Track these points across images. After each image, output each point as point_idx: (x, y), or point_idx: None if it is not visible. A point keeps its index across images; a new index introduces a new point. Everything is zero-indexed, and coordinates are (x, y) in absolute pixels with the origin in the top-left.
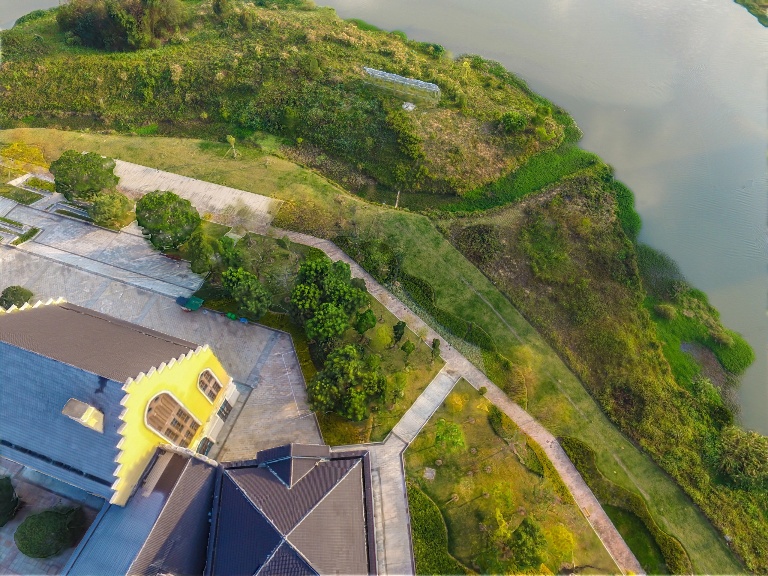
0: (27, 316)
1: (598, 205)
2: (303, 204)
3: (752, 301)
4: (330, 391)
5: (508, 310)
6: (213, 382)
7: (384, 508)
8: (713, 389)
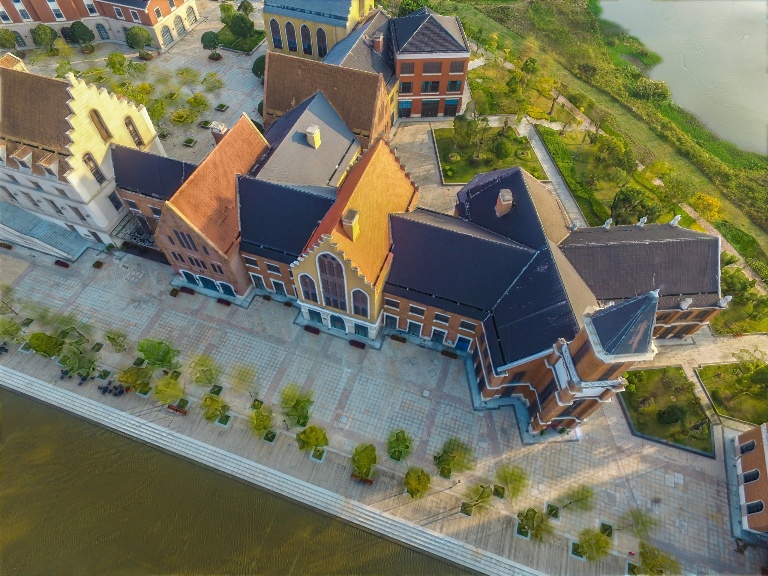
0: None
1: (576, 1)
2: None
3: (666, 42)
4: None
5: (520, 40)
6: None
7: None
8: (635, 68)
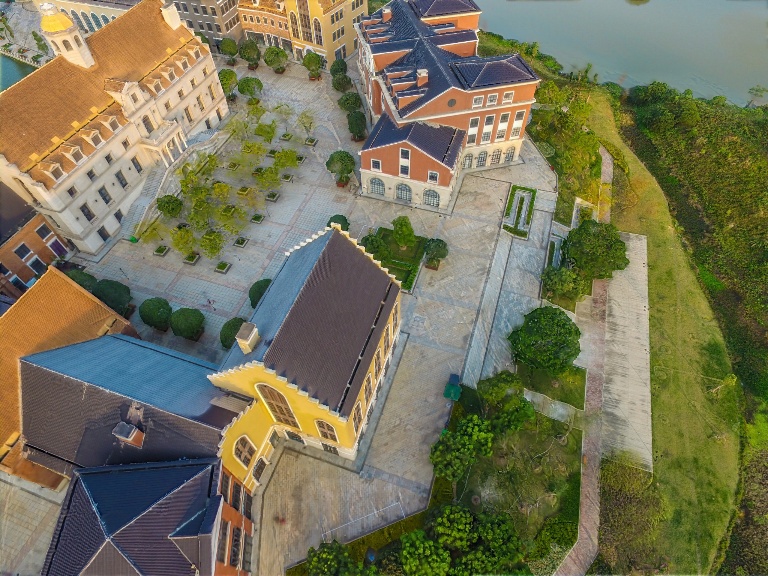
0: (363, 267)
1: None
2: (656, 502)
3: None
4: (320, 573)
5: None
6: (333, 433)
7: None
8: None
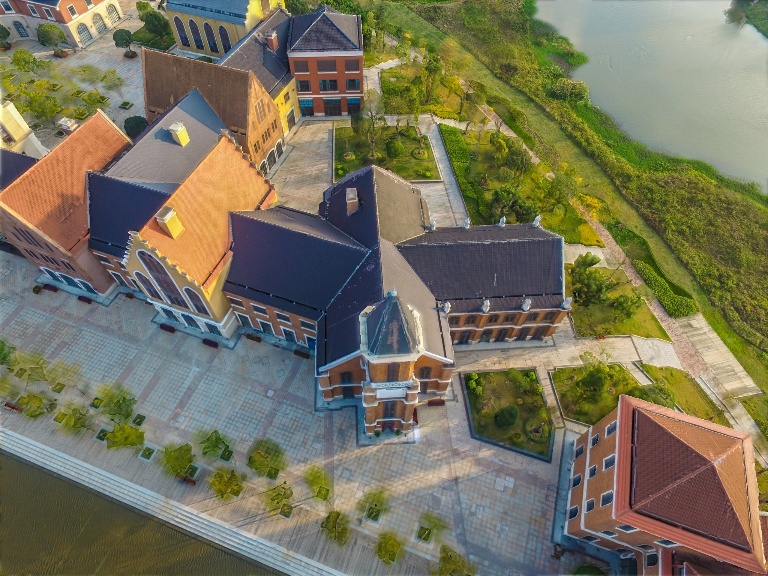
0: None
1: (511, 1)
2: None
3: (596, 42)
4: None
5: (447, 39)
6: None
7: (368, 87)
8: (558, 68)
